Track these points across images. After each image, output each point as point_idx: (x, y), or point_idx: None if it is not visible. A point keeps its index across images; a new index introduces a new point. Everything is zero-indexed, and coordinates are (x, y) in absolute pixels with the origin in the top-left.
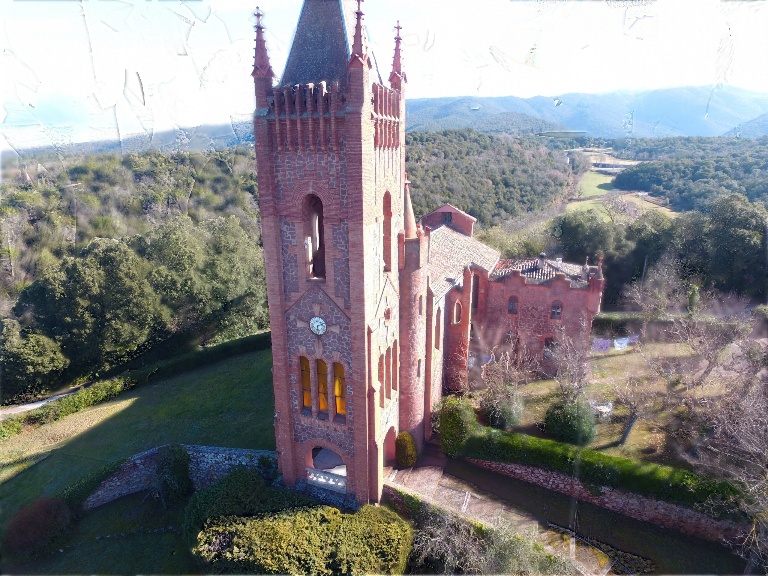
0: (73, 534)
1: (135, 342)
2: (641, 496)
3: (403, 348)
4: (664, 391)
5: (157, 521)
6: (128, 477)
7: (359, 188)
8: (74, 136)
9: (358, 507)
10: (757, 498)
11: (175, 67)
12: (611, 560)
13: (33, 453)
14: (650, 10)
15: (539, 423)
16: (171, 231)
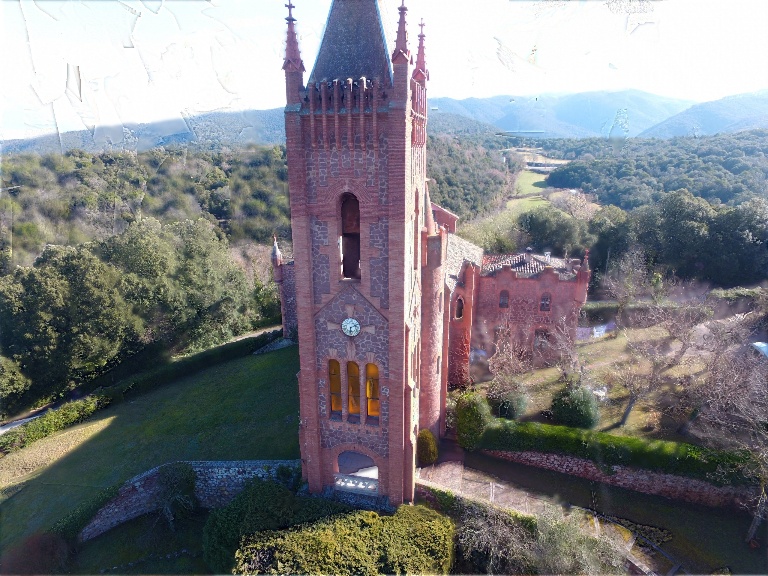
0: (72, 570)
1: (105, 356)
2: (651, 471)
3: (424, 346)
4: (646, 373)
5: (167, 546)
6: (126, 502)
7: (401, 186)
8: (3, 134)
9: (392, 508)
10: (759, 463)
11: (121, 60)
12: (633, 534)
13: (3, 486)
14: (652, 17)
15: (543, 411)
16: (137, 236)
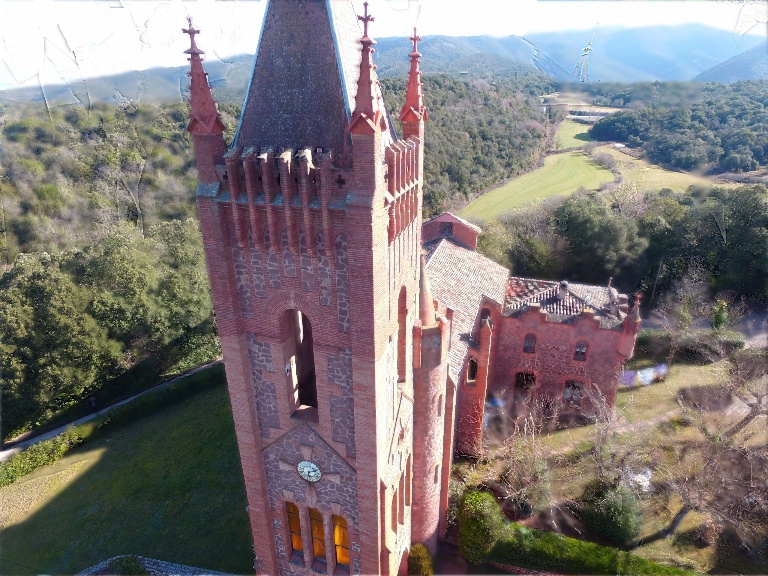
0: None
1: (80, 386)
2: None
3: (417, 456)
4: (701, 442)
5: None
6: None
7: (368, 314)
8: None
9: None
10: None
11: (108, 23)
12: None
13: None
14: None
15: (570, 502)
16: (114, 245)
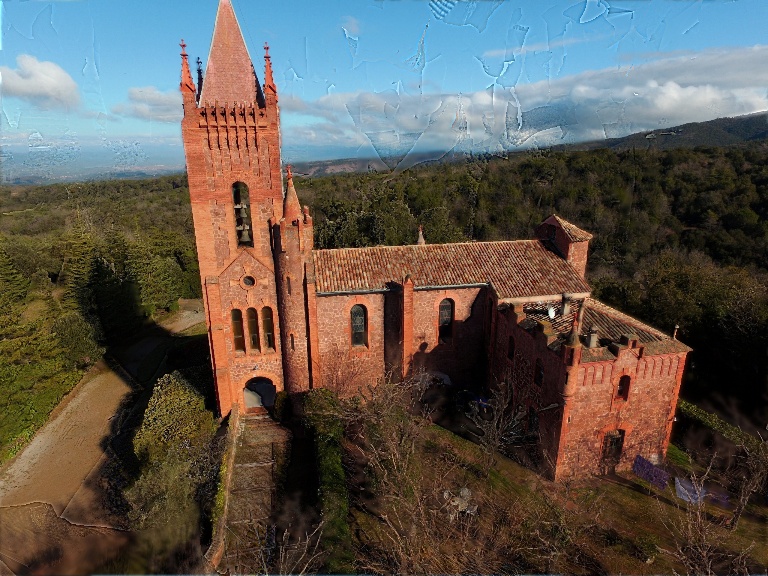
0: None
1: None
2: (324, 573)
3: (281, 318)
4: (617, 574)
5: None
6: None
7: None
8: None
9: None
10: None
11: None
12: None
13: None
14: None
15: None
16: None
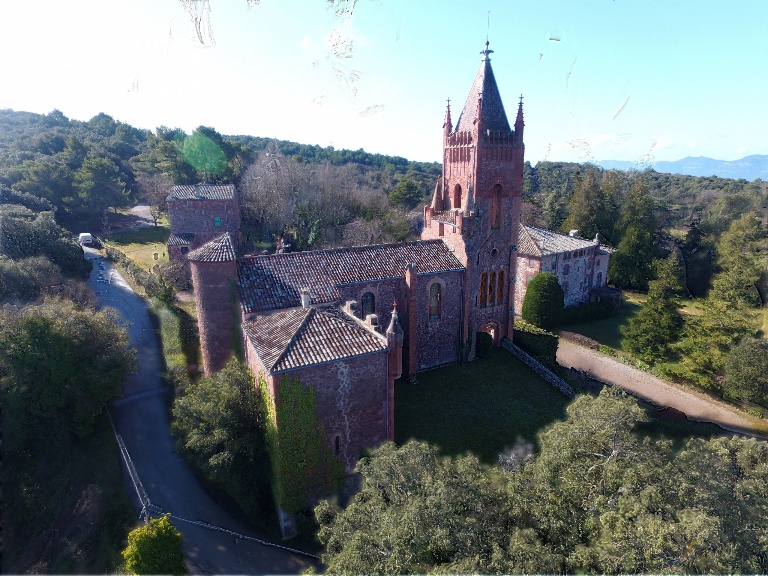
0: None
1: None
2: None
3: None
4: None
5: None
6: None
7: None
8: None
9: None
10: None
11: None
12: None
13: None
14: None
15: None
16: None
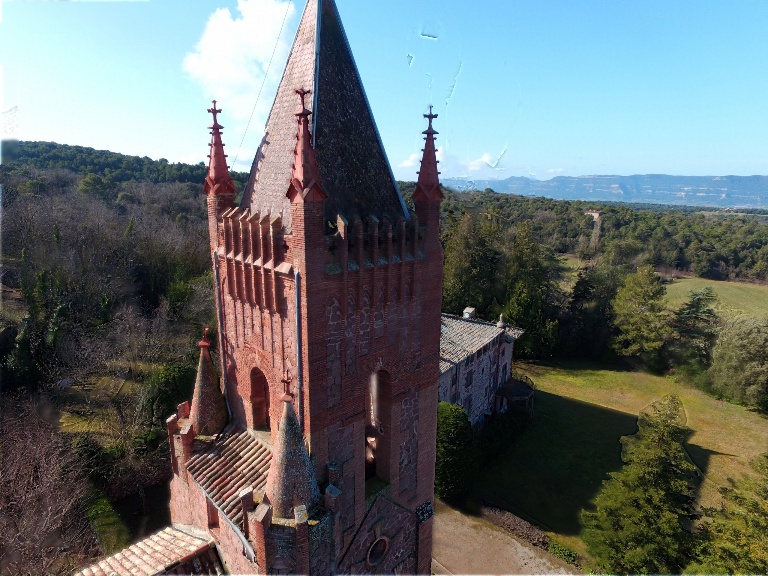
0: None
1: None
2: None
3: None
4: None
5: None
6: None
7: None
8: None
9: None
10: None
11: None
12: None
13: None
14: None
15: None
16: None
